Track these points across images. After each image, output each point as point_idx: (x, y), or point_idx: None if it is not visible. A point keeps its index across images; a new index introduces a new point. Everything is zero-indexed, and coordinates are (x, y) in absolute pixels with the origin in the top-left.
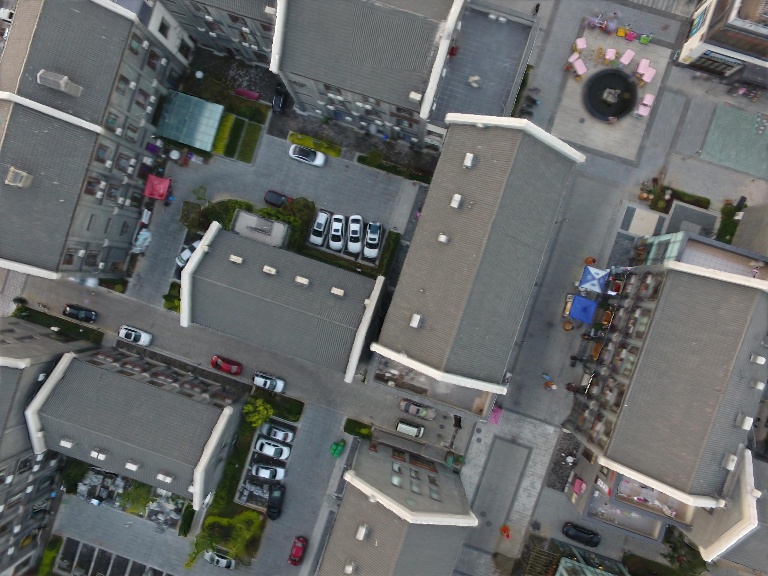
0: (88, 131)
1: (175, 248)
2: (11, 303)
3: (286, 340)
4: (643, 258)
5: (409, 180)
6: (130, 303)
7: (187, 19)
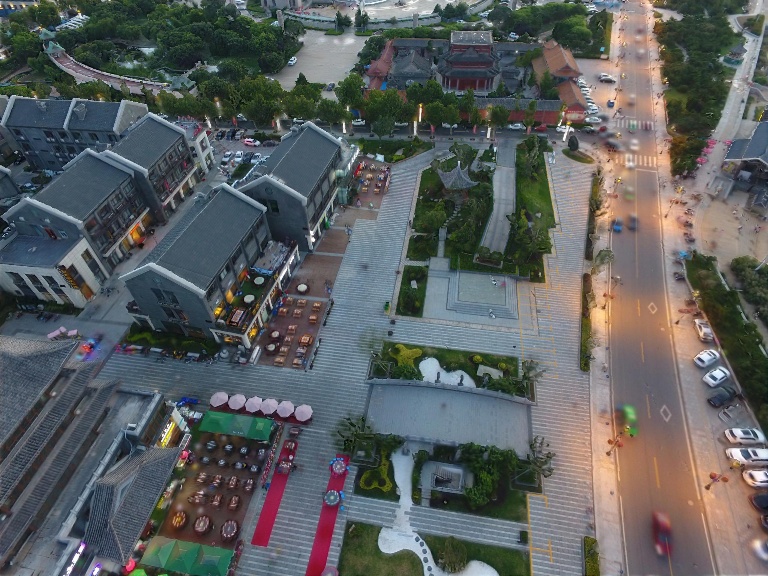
0: None
1: (39, 184)
2: None
3: None
4: None
5: None
6: None
7: None
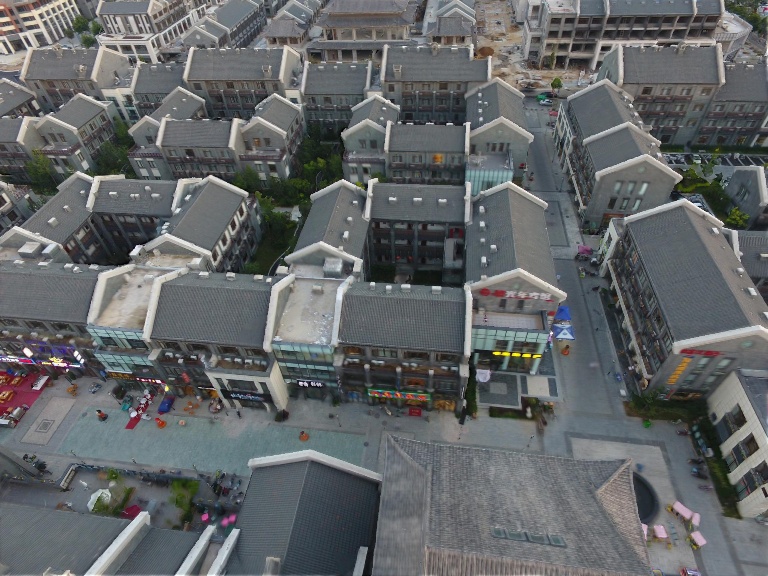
0: None
1: None
2: None
3: None
4: (527, 360)
5: None
6: None
7: None
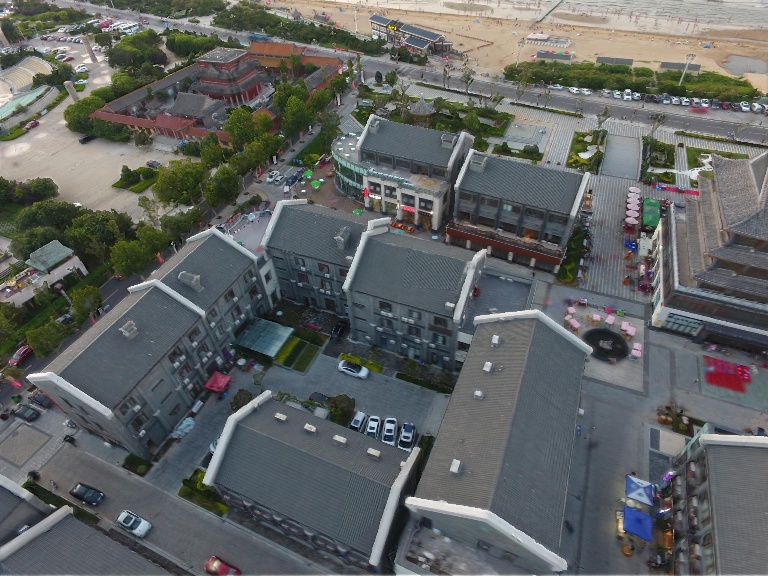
0: (194, 313)
1: (212, 437)
2: (22, 479)
3: (311, 505)
4: None
5: (441, 393)
6: (144, 488)
7: (285, 273)
